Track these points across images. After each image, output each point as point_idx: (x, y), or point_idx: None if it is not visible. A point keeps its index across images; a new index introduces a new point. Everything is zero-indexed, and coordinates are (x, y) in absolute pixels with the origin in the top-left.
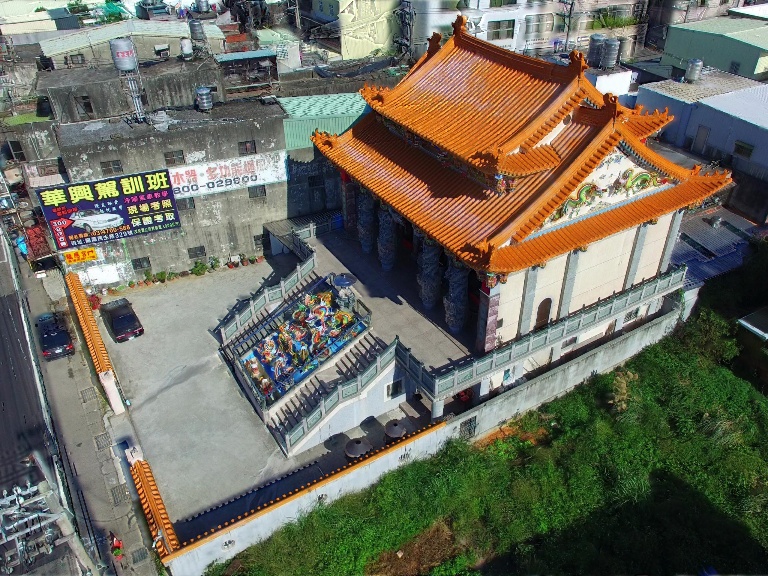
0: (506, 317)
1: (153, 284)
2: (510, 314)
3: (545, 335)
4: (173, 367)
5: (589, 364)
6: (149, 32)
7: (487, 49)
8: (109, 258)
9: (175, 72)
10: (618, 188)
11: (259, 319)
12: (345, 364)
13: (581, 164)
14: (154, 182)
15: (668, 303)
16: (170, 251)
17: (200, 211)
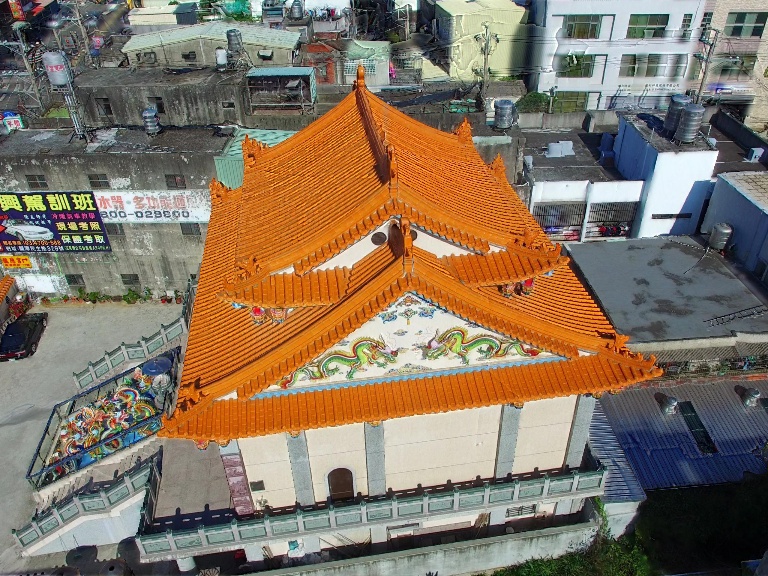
0: (269, 479)
1: (85, 302)
2: (275, 477)
3: (326, 516)
4: (22, 403)
5: (418, 564)
6: (218, 36)
7: (365, 116)
8: (43, 269)
9: (194, 83)
10: (427, 353)
11: (112, 376)
12: (125, 466)
13: (349, 312)
14: (80, 202)
15: (588, 507)
16: (103, 273)
17: (131, 239)
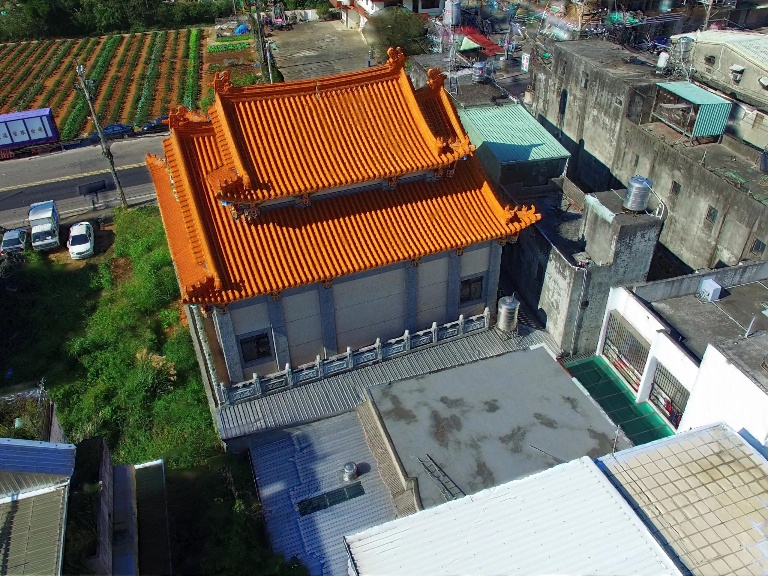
0: None
1: None
2: None
3: None
4: None
5: None
6: (740, 48)
7: None
8: None
9: (612, 72)
10: None
11: None
12: None
13: None
14: None
15: None
16: None
17: None
